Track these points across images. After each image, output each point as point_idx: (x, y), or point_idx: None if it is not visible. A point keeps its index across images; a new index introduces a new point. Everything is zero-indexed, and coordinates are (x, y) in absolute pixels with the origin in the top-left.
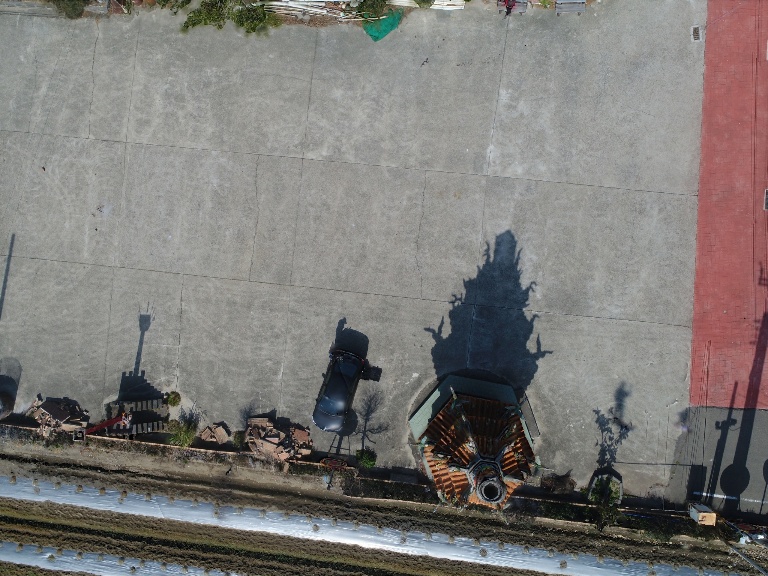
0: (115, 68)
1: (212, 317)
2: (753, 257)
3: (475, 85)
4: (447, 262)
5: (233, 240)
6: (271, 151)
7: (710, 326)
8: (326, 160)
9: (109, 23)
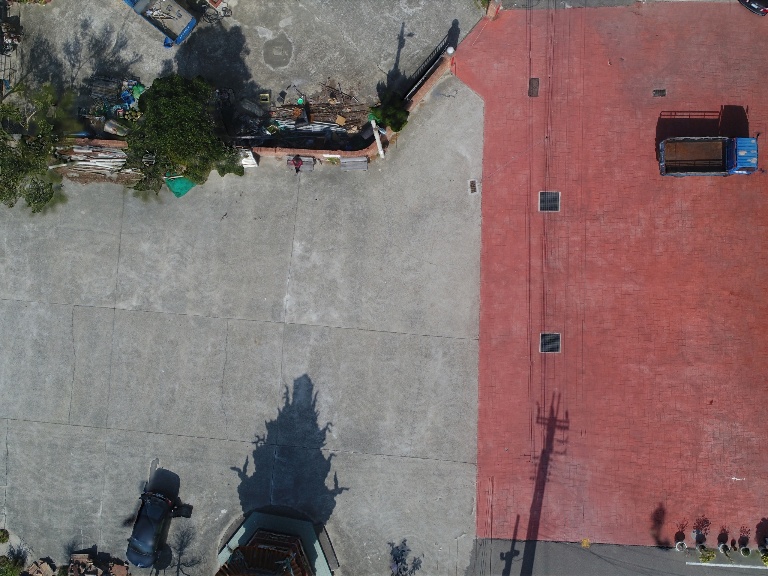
0: None
1: (35, 459)
2: (531, 397)
3: (271, 238)
4: (250, 405)
5: (53, 386)
6: (85, 302)
7: (493, 463)
8: (136, 310)
9: None
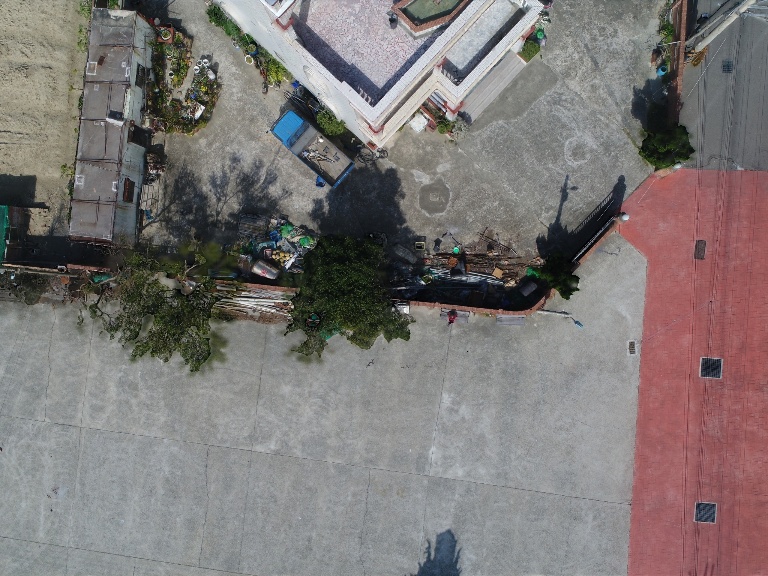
0: (71, 354)
1: None
2: (683, 567)
3: (418, 388)
4: (389, 558)
5: (183, 527)
6: (221, 442)
7: None
8: (274, 453)
9: (65, 310)
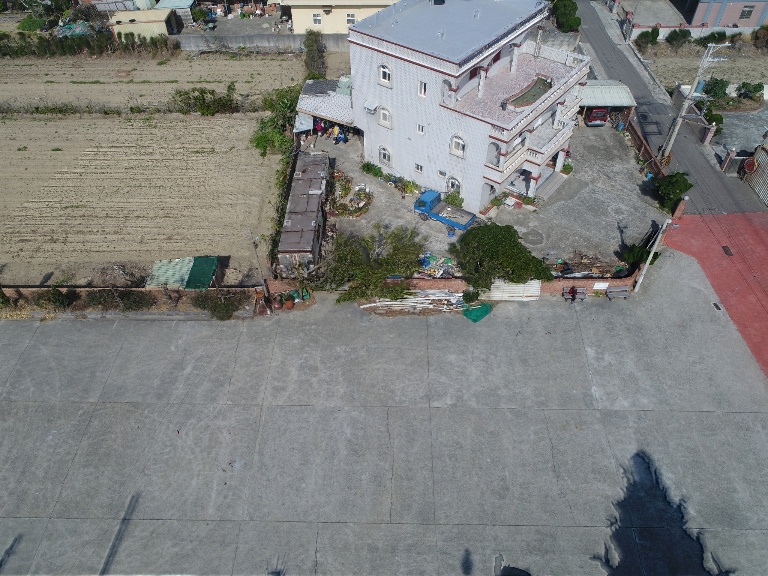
0: (256, 351)
1: (352, 567)
2: None
3: (564, 346)
4: (590, 487)
5: (370, 483)
6: (399, 403)
7: None
8: (451, 407)
9: (253, 322)
